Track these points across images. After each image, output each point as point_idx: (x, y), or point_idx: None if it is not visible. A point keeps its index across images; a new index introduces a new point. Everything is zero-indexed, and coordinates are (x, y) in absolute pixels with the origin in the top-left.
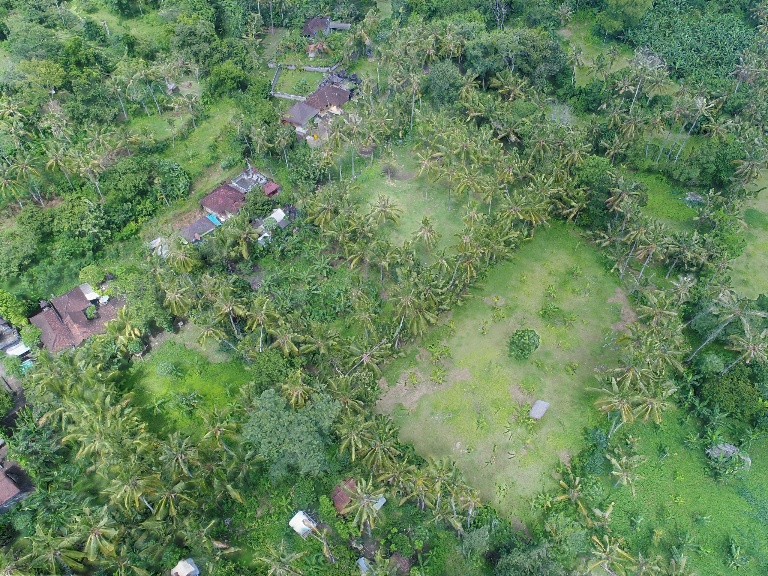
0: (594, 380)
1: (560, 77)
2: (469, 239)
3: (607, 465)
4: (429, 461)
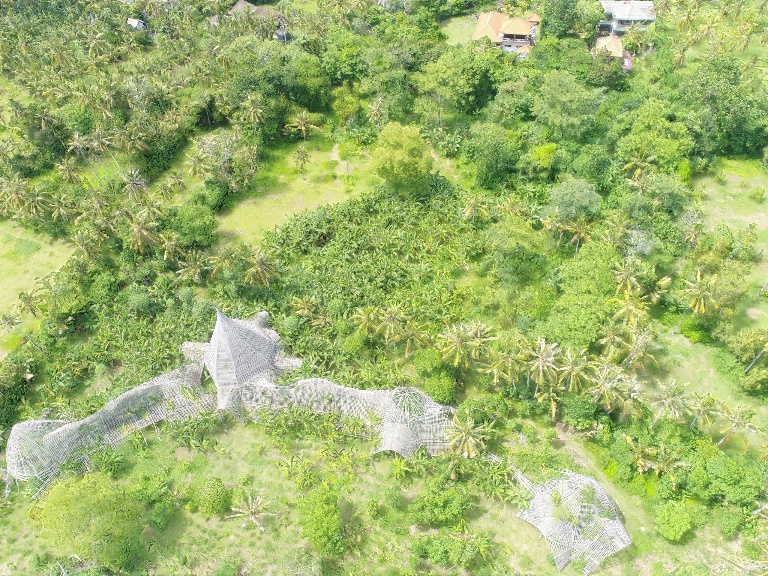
0: None
1: None
2: (1, 43)
3: None
4: None
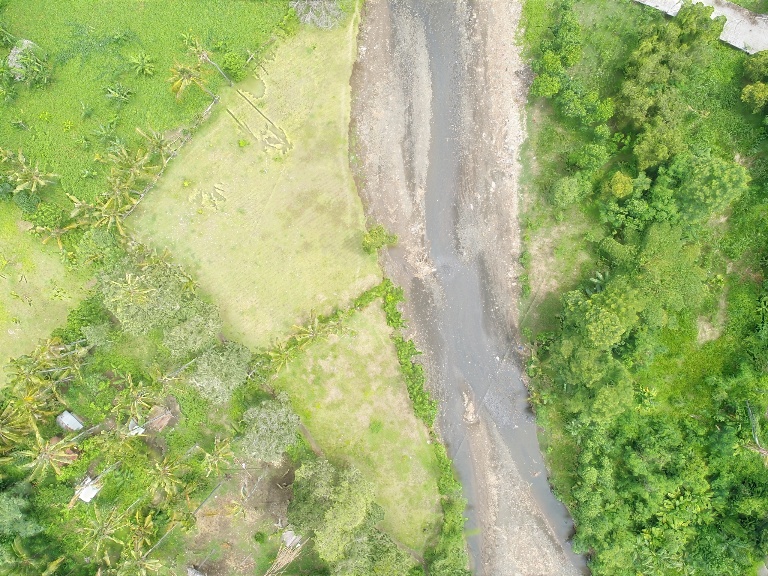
0: None
1: None
2: None
3: None
4: None
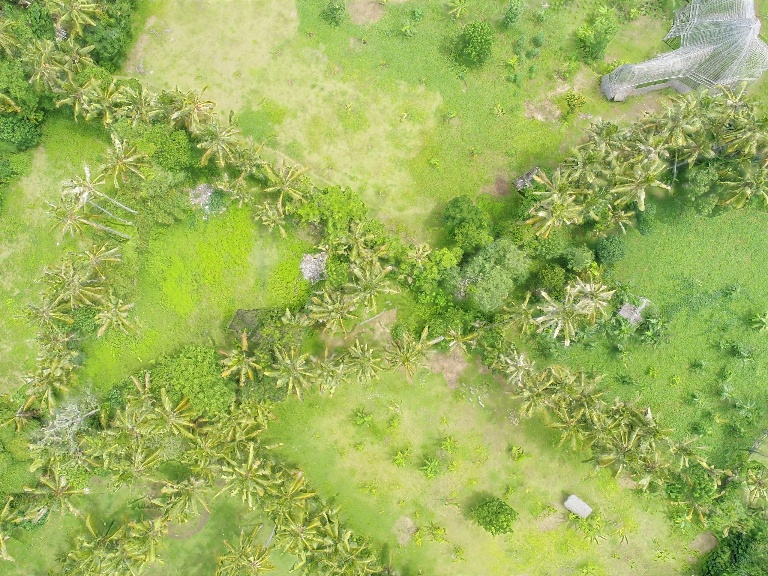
0: (531, 429)
1: None
2: None
3: None
4: None
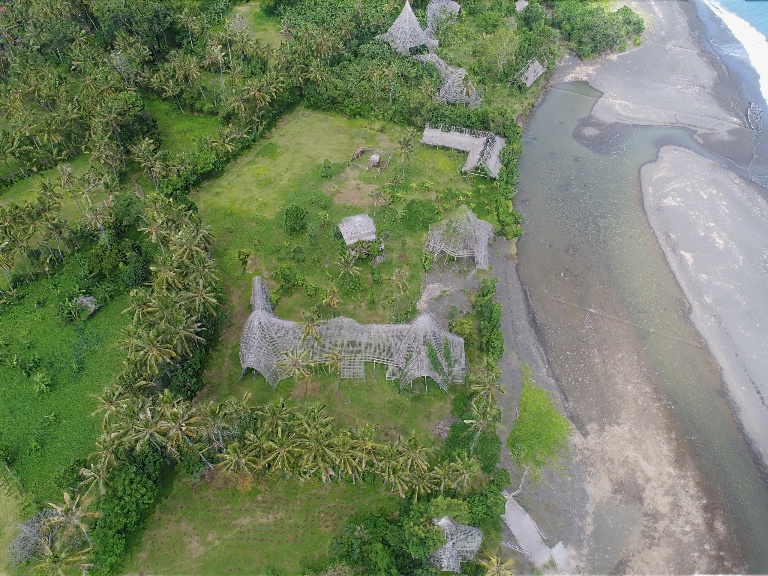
0: None
1: (177, 38)
2: None
3: None
4: None
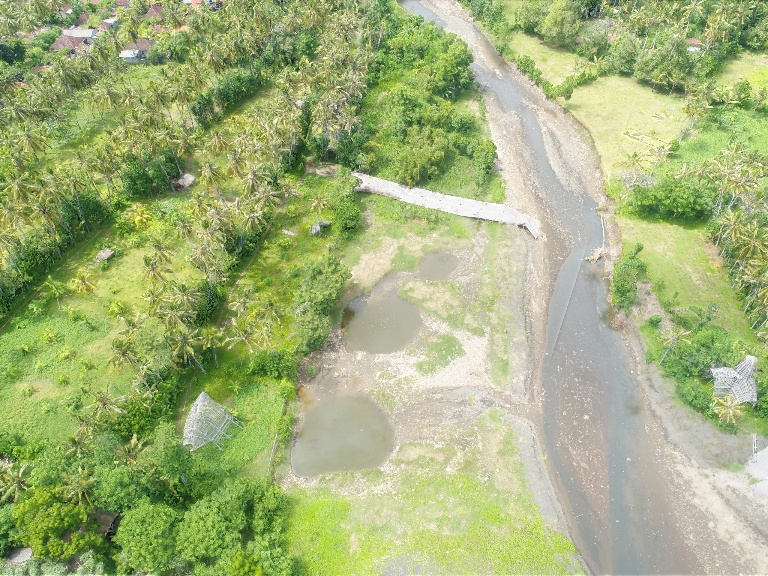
0: None
1: None
2: None
3: (764, 116)
4: (727, 68)
